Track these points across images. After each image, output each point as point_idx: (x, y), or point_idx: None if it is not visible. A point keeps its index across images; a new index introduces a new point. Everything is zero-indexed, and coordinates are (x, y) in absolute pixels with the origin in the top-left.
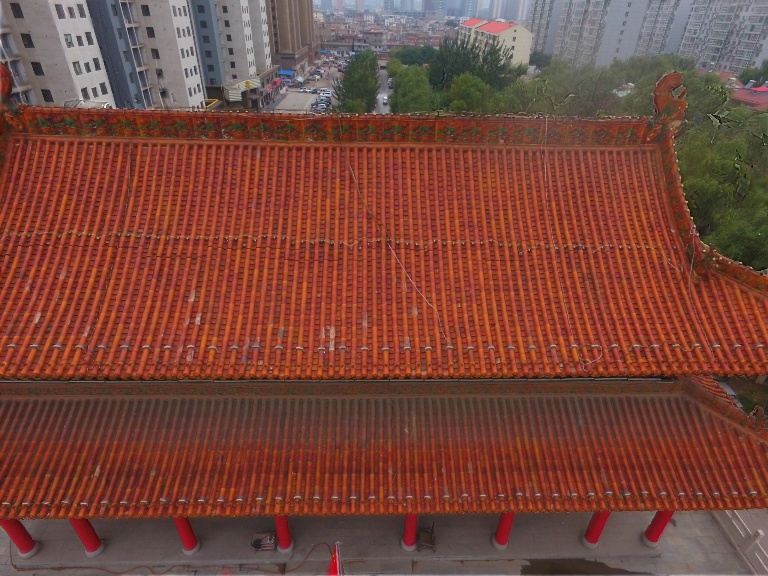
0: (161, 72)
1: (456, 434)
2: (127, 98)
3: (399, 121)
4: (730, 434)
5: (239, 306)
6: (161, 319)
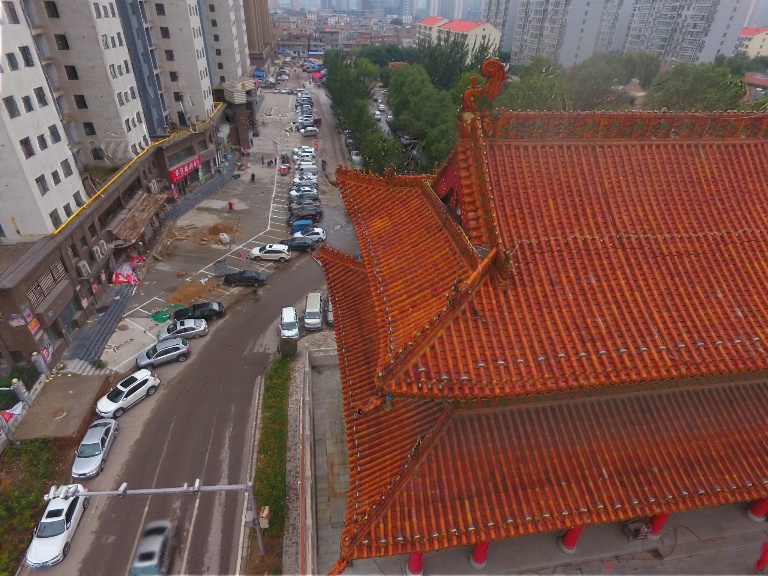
0: (179, 74)
1: None
2: (153, 102)
3: None
4: None
5: (762, 298)
6: (706, 316)
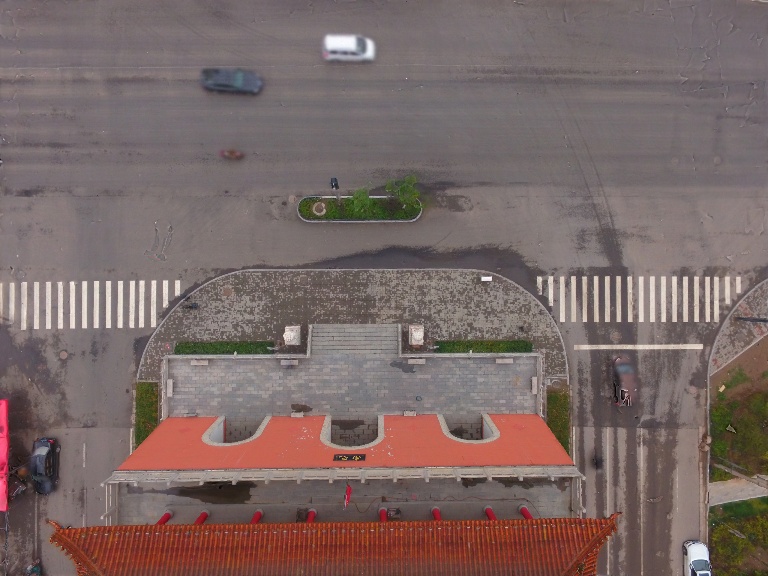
0: None
1: (273, 570)
2: None
3: None
4: (109, 570)
5: None
6: None
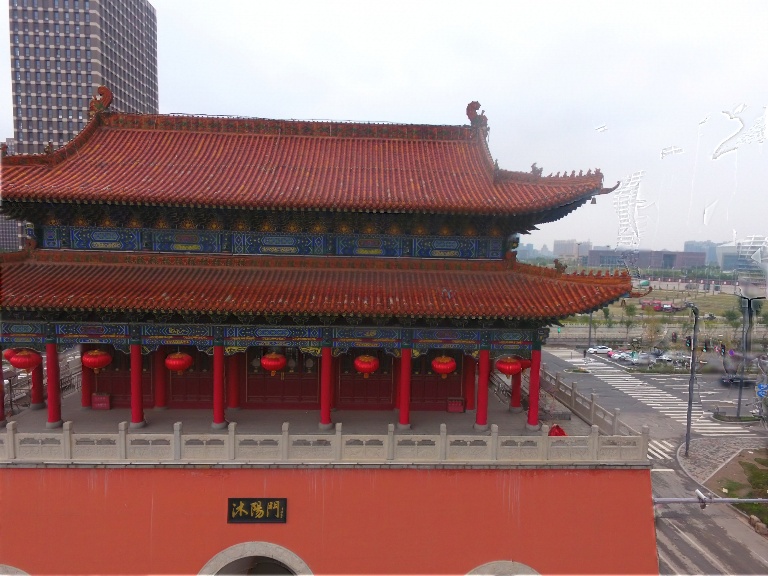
0: None
1: None
2: None
3: (261, 122)
4: None
5: None
6: None
